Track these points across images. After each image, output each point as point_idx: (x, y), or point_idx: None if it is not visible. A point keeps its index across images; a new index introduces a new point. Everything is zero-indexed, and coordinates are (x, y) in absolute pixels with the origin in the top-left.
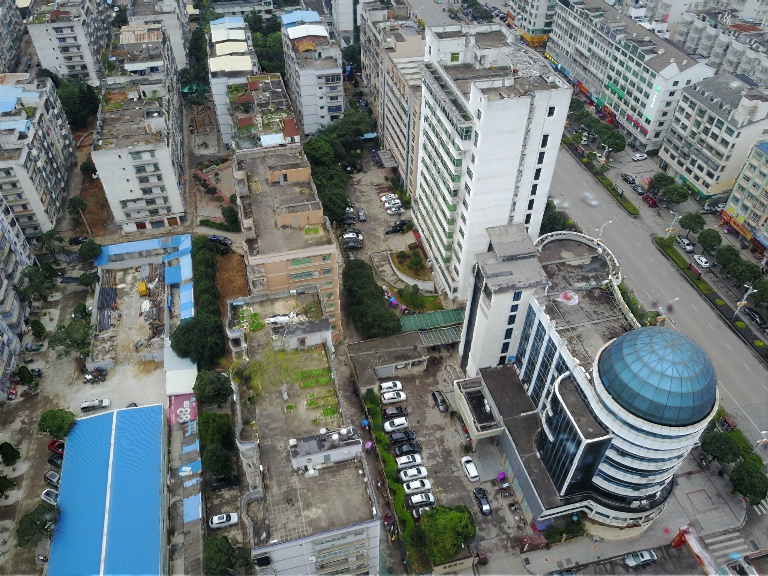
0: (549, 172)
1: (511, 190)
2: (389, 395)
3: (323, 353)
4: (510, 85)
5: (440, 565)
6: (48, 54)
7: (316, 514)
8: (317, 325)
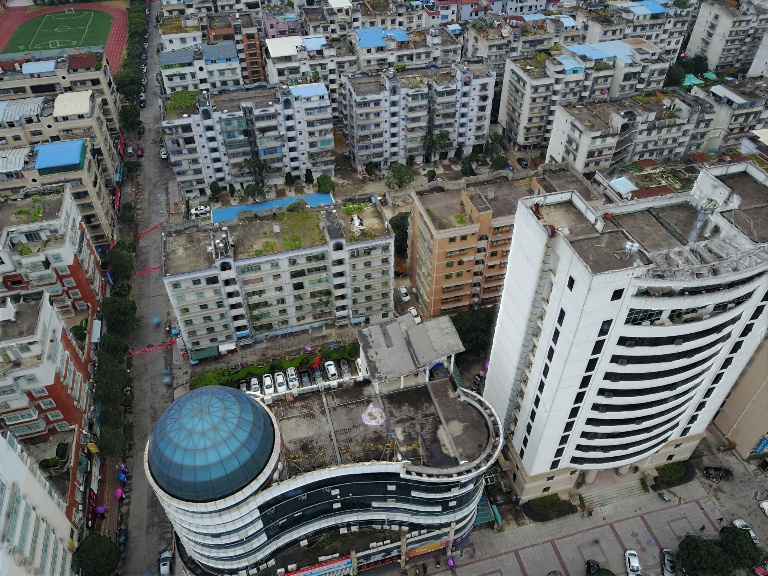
0: (559, 366)
1: (520, 335)
2: None
3: None
4: (599, 230)
5: (190, 388)
6: (759, 65)
7: (179, 252)
8: (336, 232)
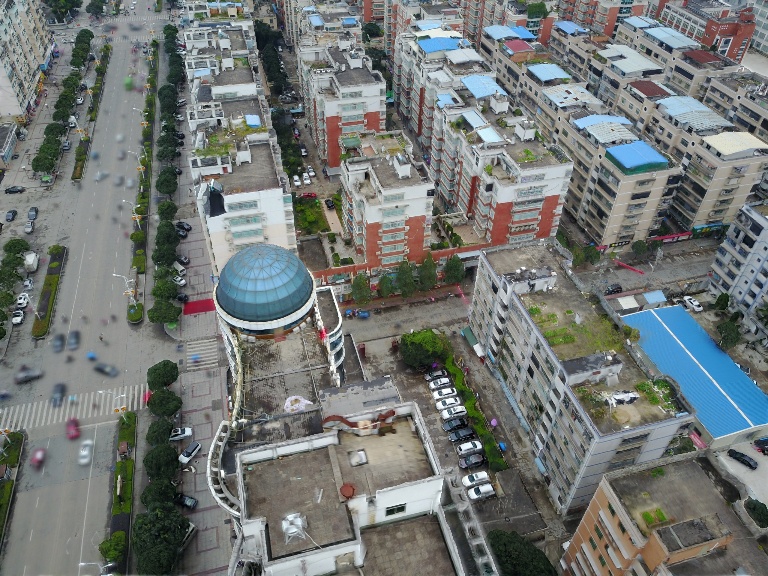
0: None
1: None
2: (482, 474)
3: (560, 360)
4: None
5: None
6: None
7: (522, 256)
8: (577, 367)
